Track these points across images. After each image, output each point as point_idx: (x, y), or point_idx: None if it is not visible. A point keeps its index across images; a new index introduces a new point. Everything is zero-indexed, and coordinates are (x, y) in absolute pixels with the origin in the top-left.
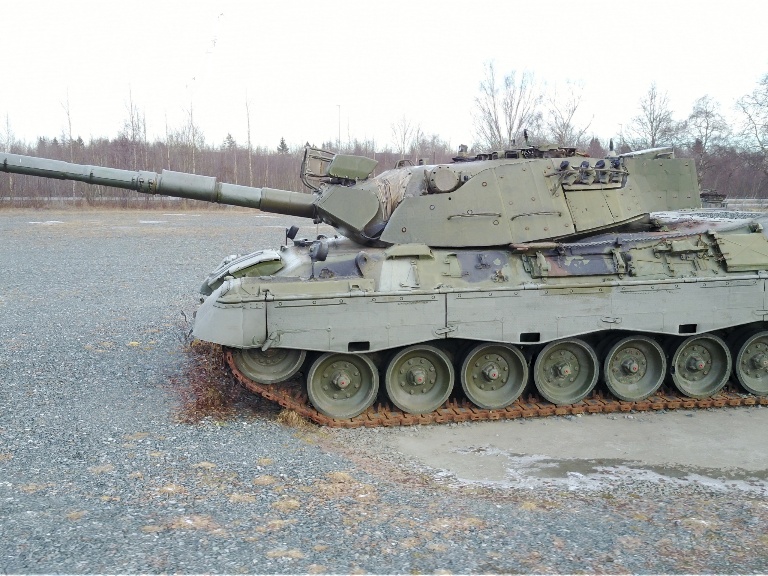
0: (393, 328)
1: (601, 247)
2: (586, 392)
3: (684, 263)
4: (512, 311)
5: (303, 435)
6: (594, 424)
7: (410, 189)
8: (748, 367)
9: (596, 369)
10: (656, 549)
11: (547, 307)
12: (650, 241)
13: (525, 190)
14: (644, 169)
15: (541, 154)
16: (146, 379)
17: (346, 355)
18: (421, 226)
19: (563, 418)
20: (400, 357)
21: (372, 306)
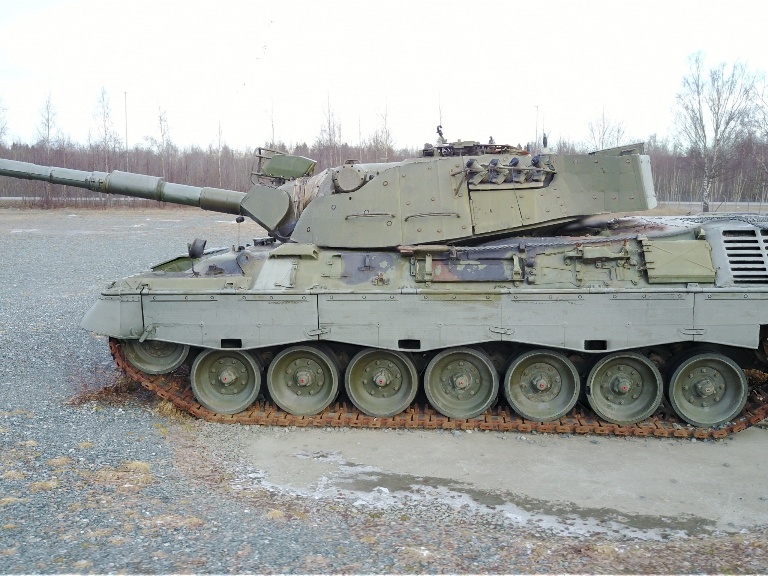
0: (264, 327)
1: (503, 251)
2: (484, 407)
3: (598, 272)
4: (388, 316)
5: (169, 426)
6: (474, 441)
7: (323, 188)
8: (691, 394)
9: (495, 383)
10: (332, 572)
11: (427, 313)
12: (563, 246)
13: (426, 190)
14: (575, 167)
15: (458, 152)
16: (97, 364)
17: (229, 351)
18: (322, 226)
19: (449, 432)
20: (281, 357)
21: (243, 304)
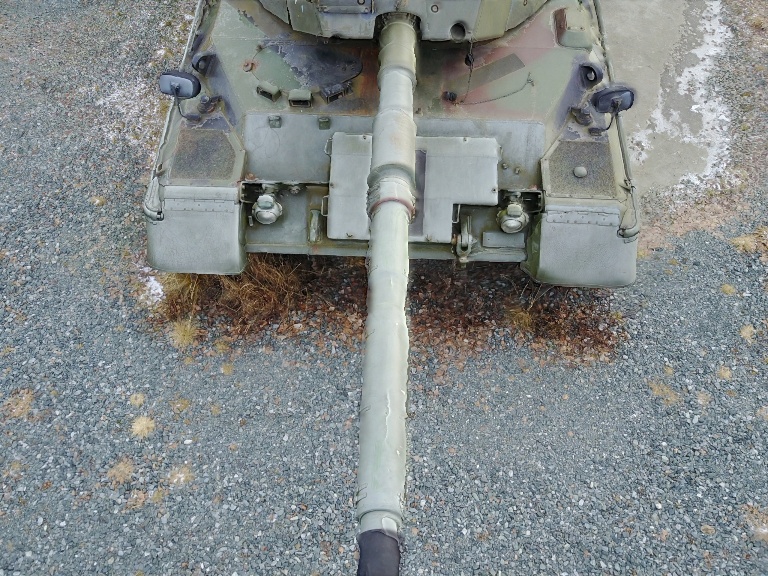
0: None
1: None
2: None
3: None
4: None
5: None
6: None
7: None
8: None
9: None
10: None
11: None
12: None
13: None
14: None
15: None
16: None
17: None
18: None
19: None
20: None
21: None
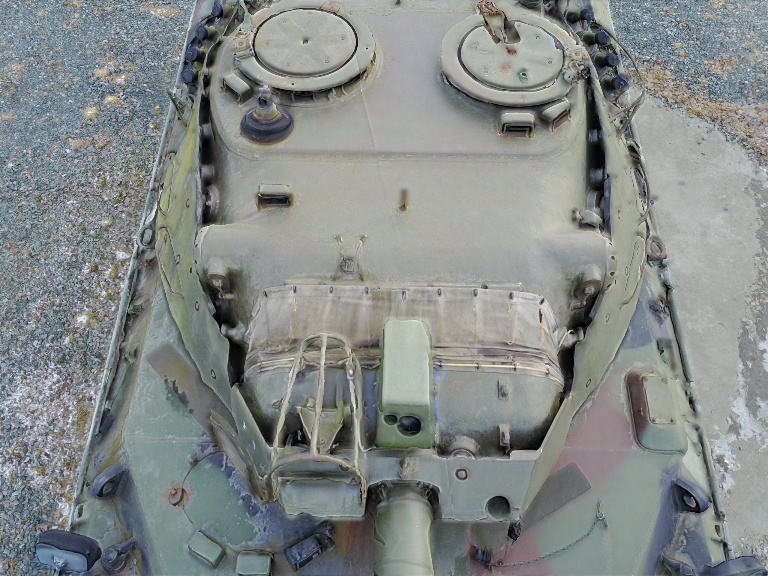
0: None
1: None
2: None
3: None
4: None
5: None
6: None
7: None
8: None
9: None
10: None
11: None
12: None
13: None
14: None
15: None
16: None
17: None
18: None
19: None
20: None
21: None
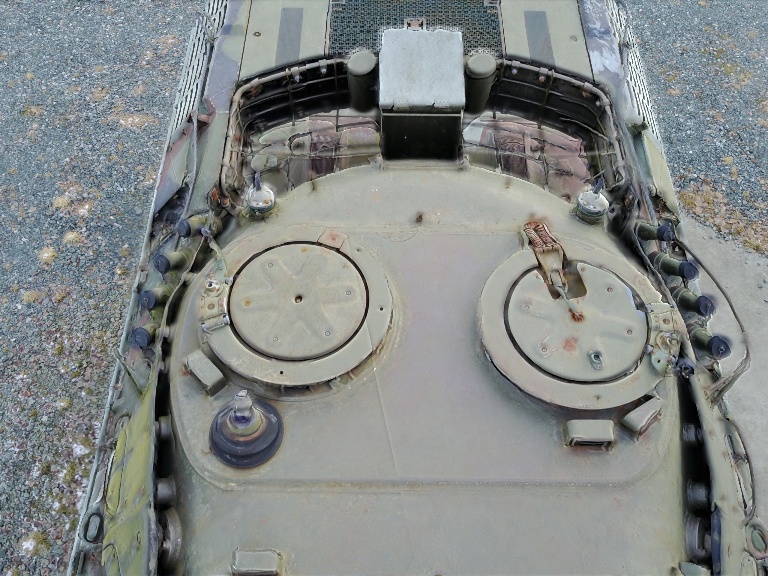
0: None
1: None
2: None
3: None
4: None
5: None
6: None
7: None
8: None
9: None
10: None
11: None
12: None
13: None
14: None
15: None
16: None
17: None
18: None
19: None
20: None
21: None
